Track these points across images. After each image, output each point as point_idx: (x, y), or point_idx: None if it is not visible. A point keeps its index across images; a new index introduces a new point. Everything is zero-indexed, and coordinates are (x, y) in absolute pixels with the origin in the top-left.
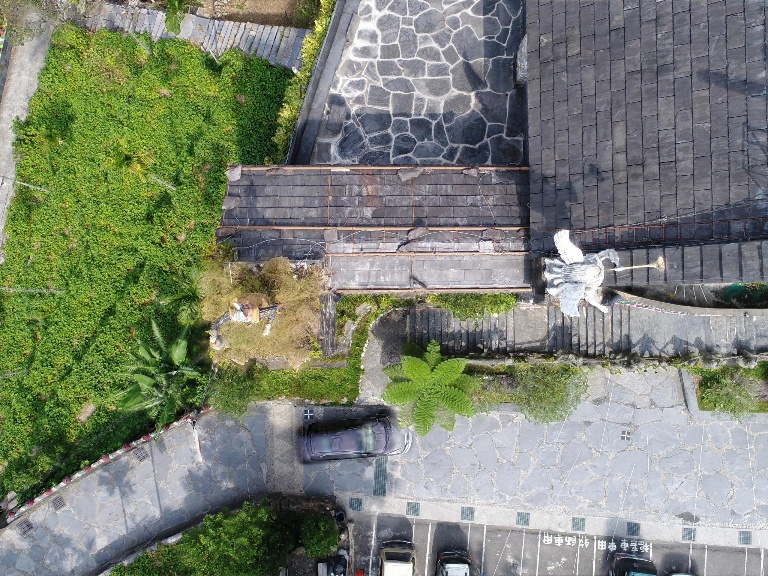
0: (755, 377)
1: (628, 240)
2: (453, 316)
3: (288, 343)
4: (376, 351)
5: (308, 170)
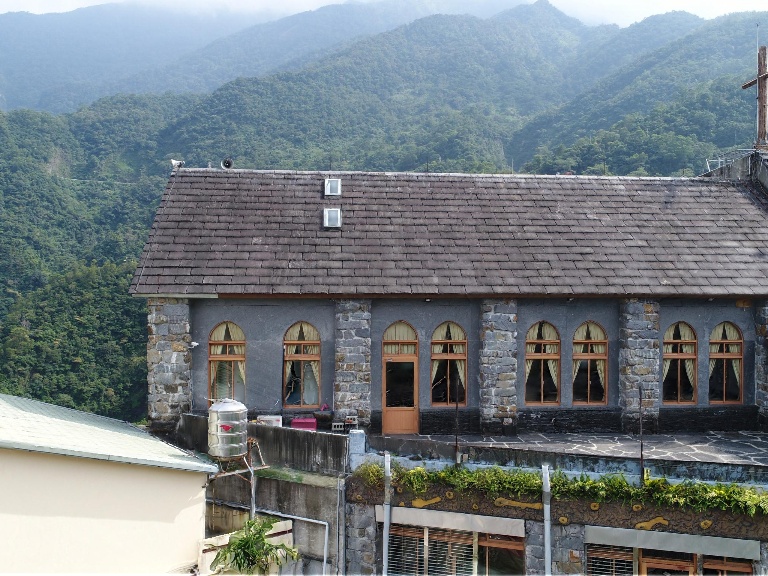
0: None
1: None
2: None
3: None
4: None
5: None
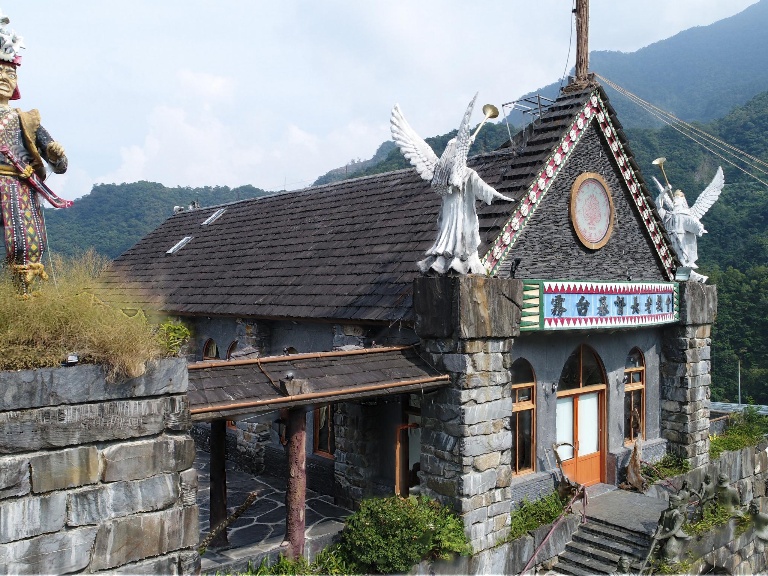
0: None
1: None
2: (395, 567)
3: None
4: None
5: None
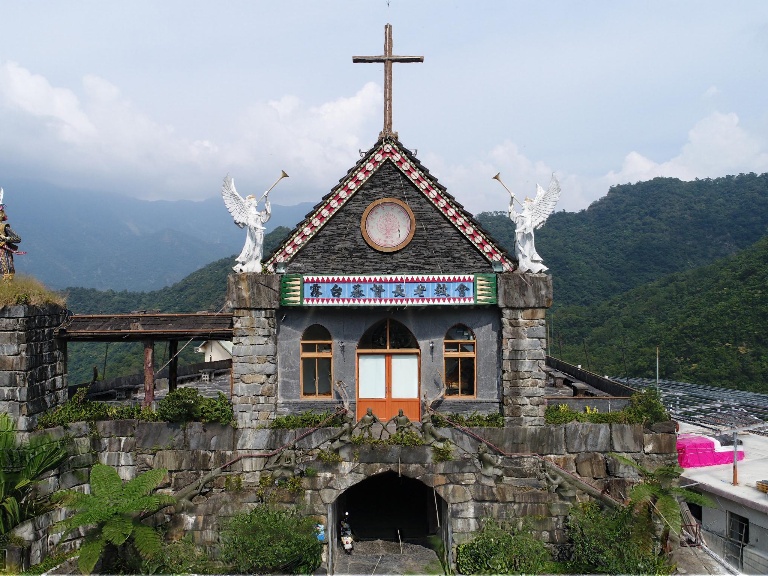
0: (553, 574)
1: None
2: None
3: (5, 293)
4: (63, 573)
5: None
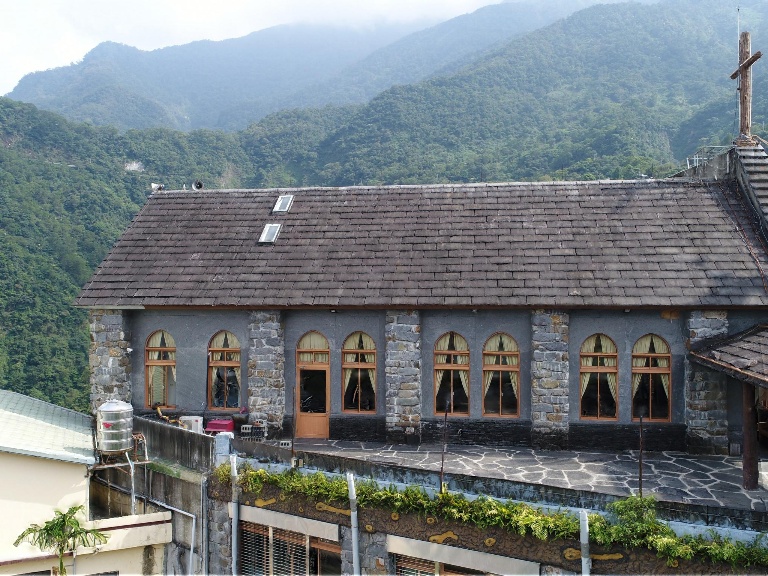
0: None
1: (761, 246)
2: None
3: None
4: None
5: None
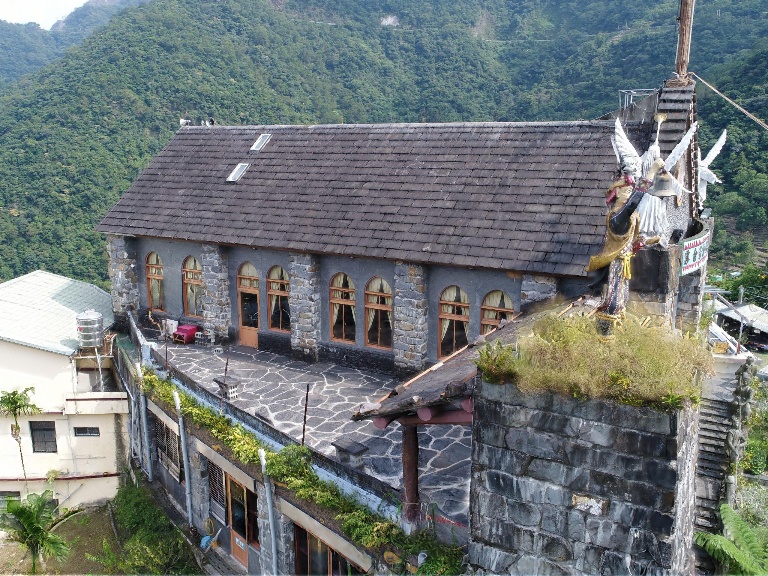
0: None
1: None
2: None
3: None
4: None
5: (417, 380)
